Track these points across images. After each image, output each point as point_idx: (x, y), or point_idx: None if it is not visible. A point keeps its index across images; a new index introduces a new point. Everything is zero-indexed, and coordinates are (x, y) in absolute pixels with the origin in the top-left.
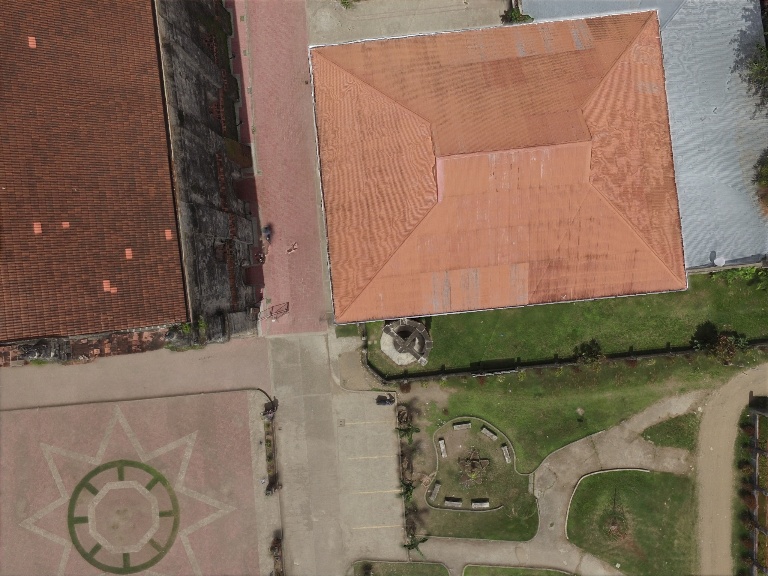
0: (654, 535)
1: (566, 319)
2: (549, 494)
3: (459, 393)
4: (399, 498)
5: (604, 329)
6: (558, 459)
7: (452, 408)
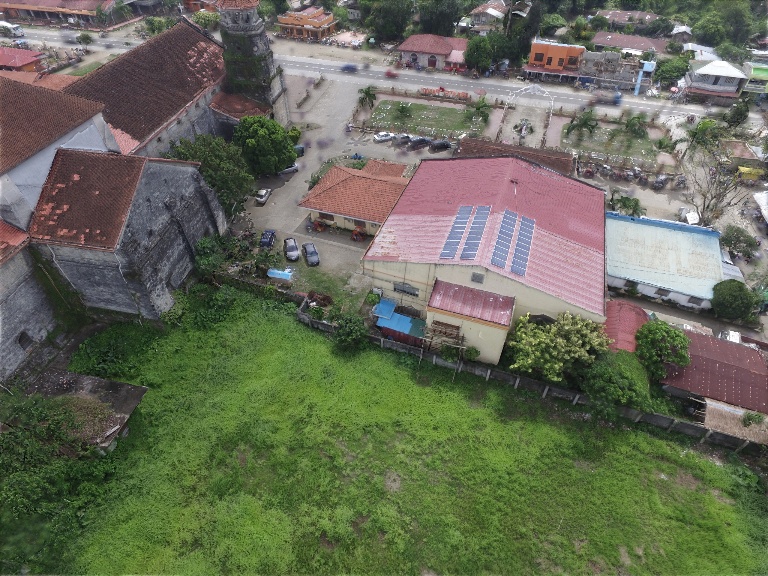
0: None
1: None
2: None
3: None
4: None
5: None
6: None
7: None
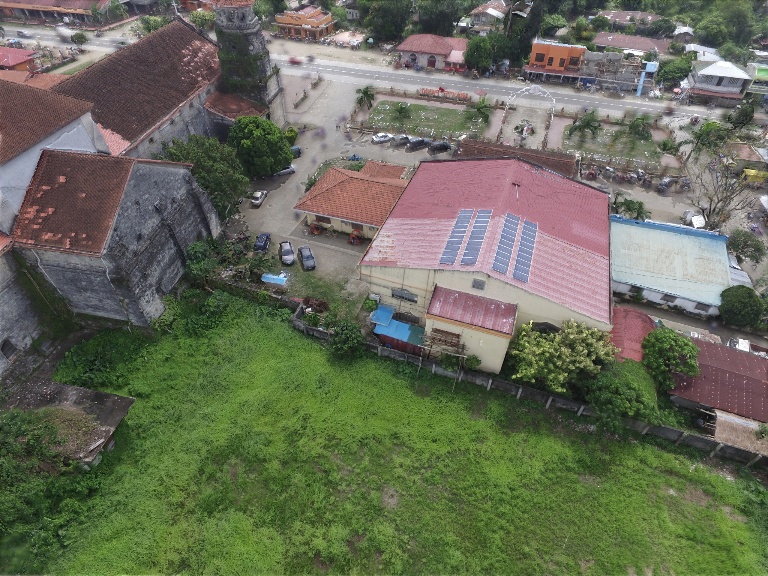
0: None
1: None
2: None
3: None
4: None
5: None
6: None
7: None
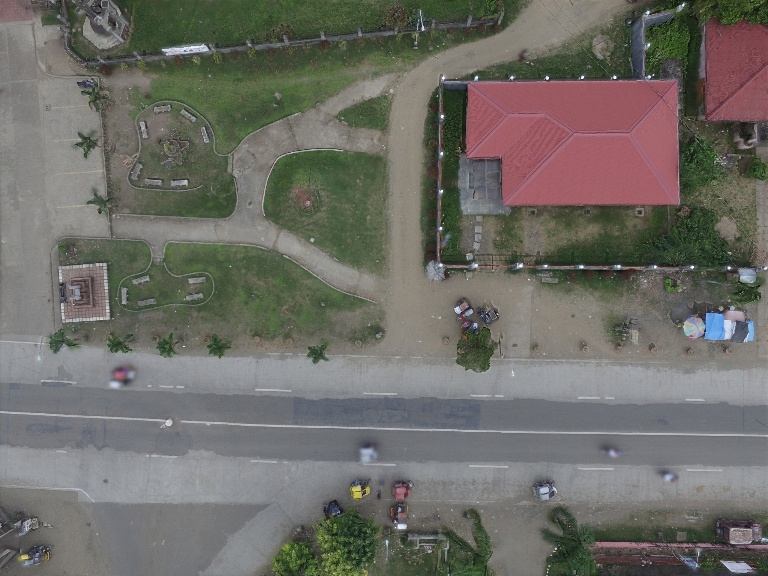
0: (348, 211)
1: (262, 5)
2: (247, 174)
3: (161, 78)
4: (102, 178)
5: (299, 15)
6: (256, 141)
7: (154, 93)
